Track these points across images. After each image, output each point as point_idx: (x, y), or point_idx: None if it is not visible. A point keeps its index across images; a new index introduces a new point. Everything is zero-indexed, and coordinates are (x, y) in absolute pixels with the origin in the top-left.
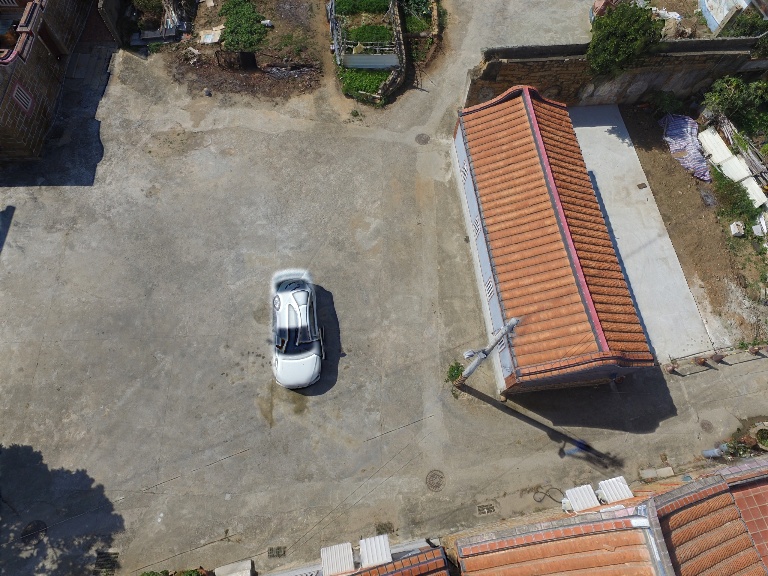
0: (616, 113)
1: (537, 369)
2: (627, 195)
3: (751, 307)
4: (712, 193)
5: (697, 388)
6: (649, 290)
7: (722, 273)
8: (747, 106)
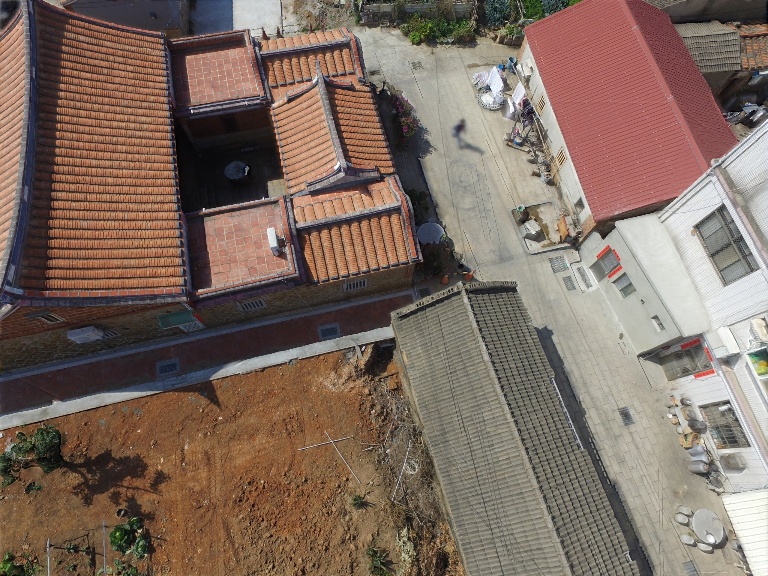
0: None
1: None
2: None
3: (323, 8)
4: None
5: None
6: None
7: None
8: None
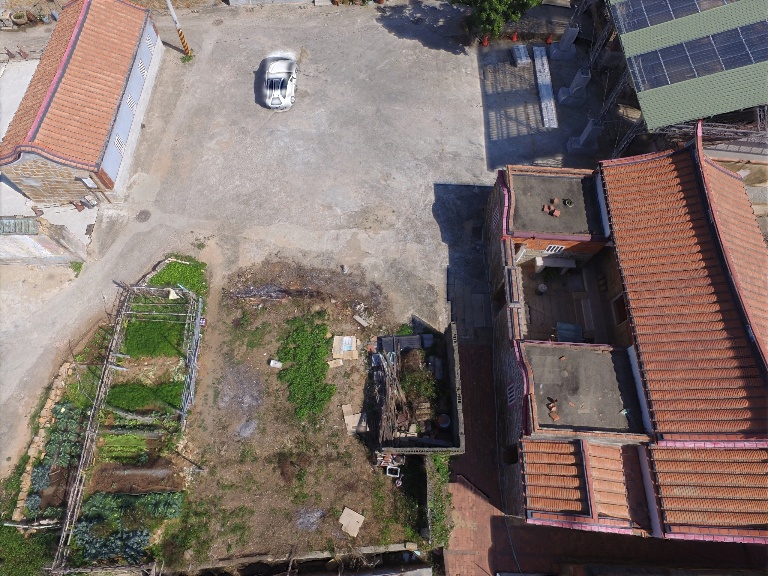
0: None
1: (135, 5)
2: None
3: None
4: None
5: (38, 45)
6: None
7: None
8: None
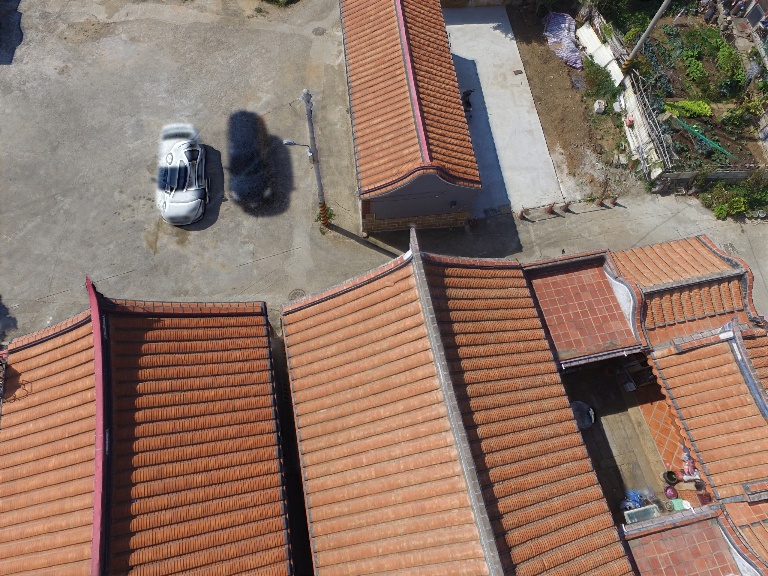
0: (503, 13)
1: (374, 186)
2: (503, 80)
3: (603, 169)
4: (582, 78)
5: (544, 231)
6: (512, 155)
7: (580, 141)
8: (618, 2)
